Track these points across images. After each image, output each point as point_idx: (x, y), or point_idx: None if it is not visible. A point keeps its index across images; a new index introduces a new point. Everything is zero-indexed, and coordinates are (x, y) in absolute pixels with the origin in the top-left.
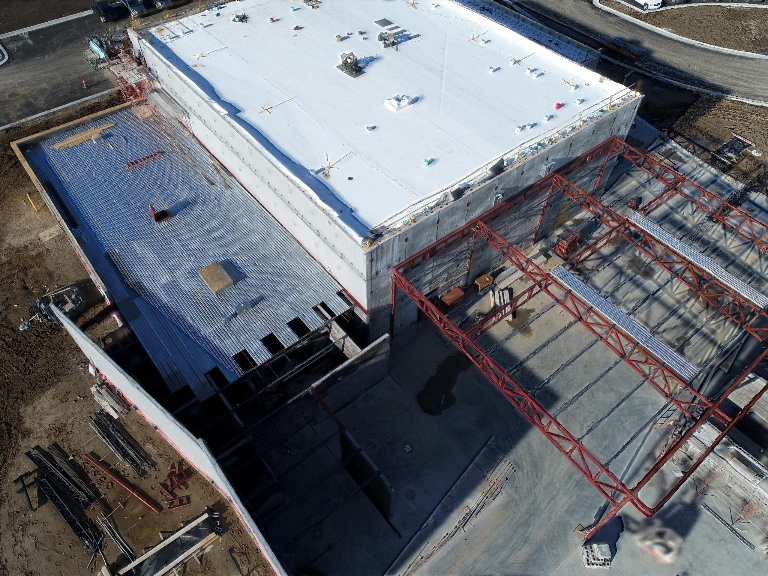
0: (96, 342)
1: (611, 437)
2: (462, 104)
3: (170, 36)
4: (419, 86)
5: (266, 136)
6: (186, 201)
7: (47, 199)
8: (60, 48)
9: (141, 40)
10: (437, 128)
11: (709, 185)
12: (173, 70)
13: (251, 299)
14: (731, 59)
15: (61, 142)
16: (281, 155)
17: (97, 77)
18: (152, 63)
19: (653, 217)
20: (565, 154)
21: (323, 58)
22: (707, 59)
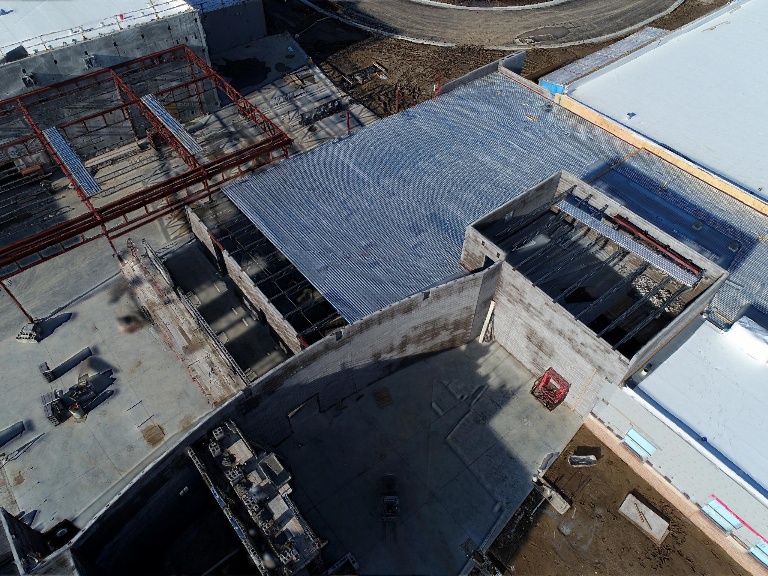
0: None
1: (103, 265)
2: (44, 15)
3: None
4: (21, 3)
5: None
6: None
7: None
8: None
9: None
10: (7, 31)
11: (322, 99)
12: None
13: None
14: (425, 8)
15: None
16: None
17: None
18: None
19: None
20: (113, 52)
21: None
22: (404, 8)
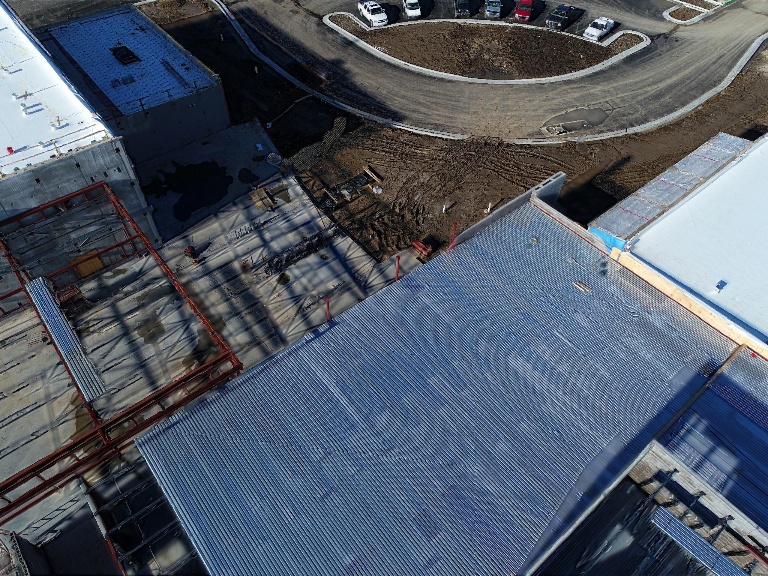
0: None
1: None
2: None
3: None
4: None
5: None
6: None
7: None
8: None
9: None
10: None
11: (297, 228)
12: None
13: None
14: (428, 82)
15: None
16: None
17: None
18: None
19: (208, 267)
20: None
21: None
22: (402, 82)
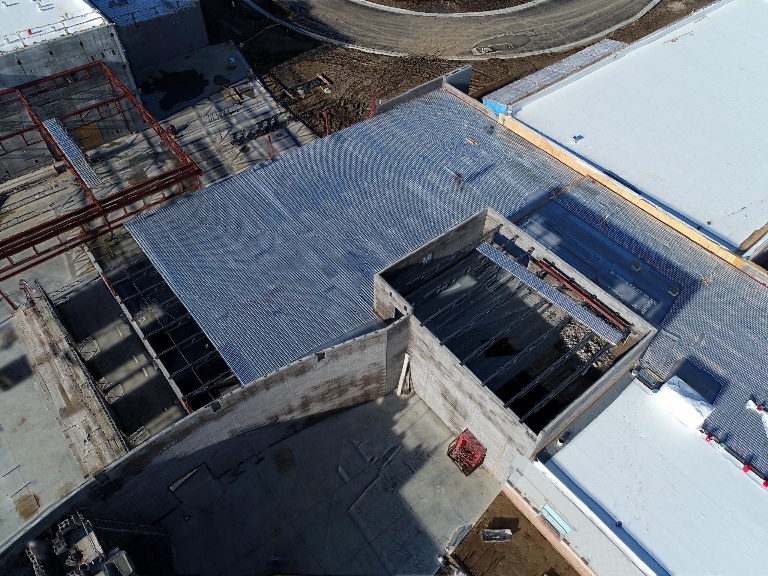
0: None
1: None
2: None
3: None
4: None
5: None
6: None
7: None
8: None
9: None
10: None
11: (259, 116)
12: None
13: None
14: (381, 14)
15: None
16: None
17: None
18: None
19: (185, 141)
20: (18, 71)
21: None
22: (358, 14)
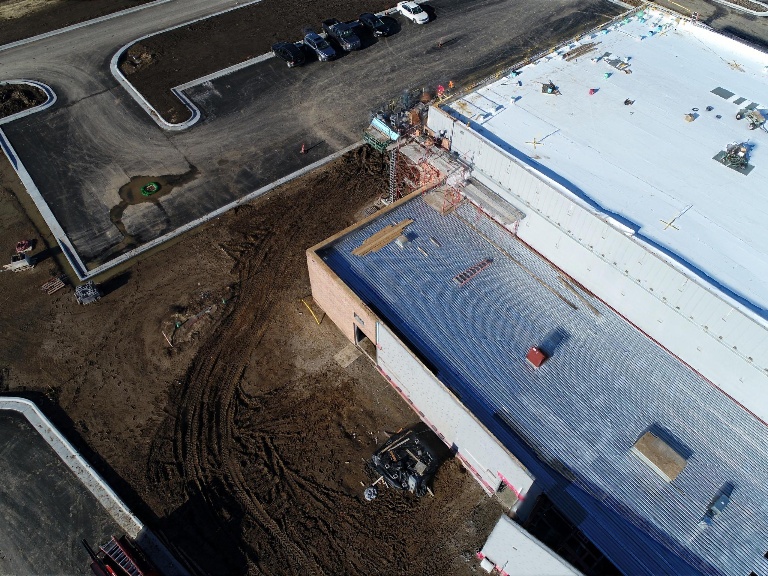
0: (470, 519)
1: None
2: None
3: (480, 114)
4: None
5: (696, 266)
6: (555, 333)
7: (390, 334)
8: (254, 101)
9: (457, 122)
10: None
11: None
12: (525, 167)
13: (717, 488)
14: None
15: (362, 246)
16: (735, 296)
17: (310, 138)
18: (470, 150)
19: None
20: None
21: (688, 146)
22: None
